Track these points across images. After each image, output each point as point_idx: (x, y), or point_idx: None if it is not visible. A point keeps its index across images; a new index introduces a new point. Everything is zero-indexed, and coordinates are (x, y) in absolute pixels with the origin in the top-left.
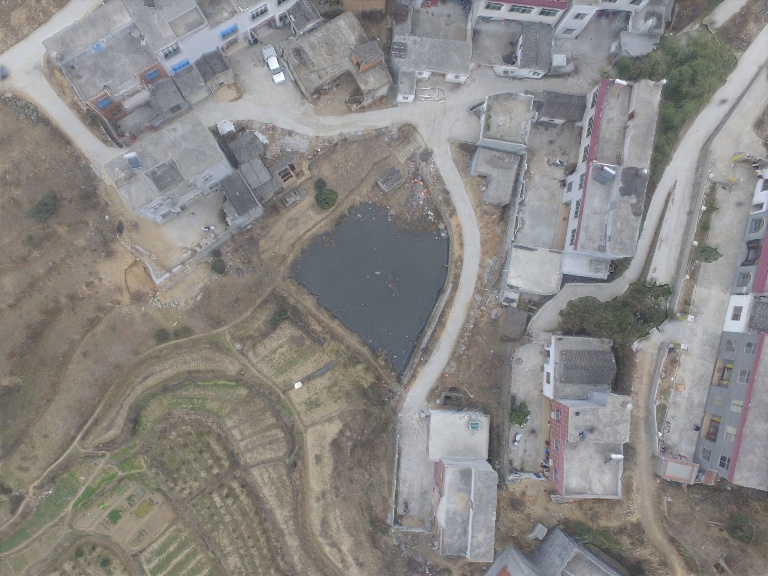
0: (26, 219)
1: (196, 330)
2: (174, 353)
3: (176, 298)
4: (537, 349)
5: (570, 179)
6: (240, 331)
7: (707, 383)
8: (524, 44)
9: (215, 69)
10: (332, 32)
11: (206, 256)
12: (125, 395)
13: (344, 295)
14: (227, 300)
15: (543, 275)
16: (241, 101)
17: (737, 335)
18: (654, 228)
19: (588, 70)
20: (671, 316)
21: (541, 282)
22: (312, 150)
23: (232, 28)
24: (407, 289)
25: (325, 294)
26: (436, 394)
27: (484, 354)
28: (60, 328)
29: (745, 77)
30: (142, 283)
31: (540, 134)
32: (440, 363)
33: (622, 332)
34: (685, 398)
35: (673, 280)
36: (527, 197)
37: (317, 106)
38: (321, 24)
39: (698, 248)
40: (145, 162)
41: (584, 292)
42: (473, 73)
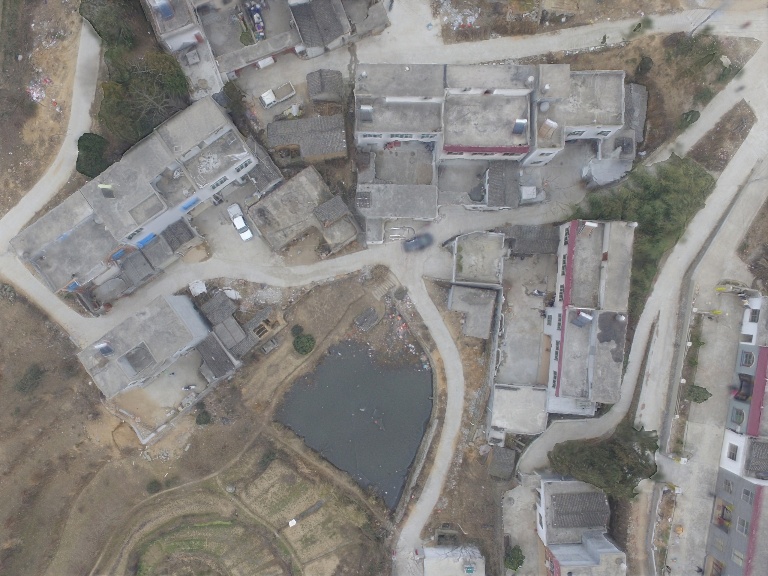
0: (13, 393)
1: (187, 479)
2: (168, 499)
3: (165, 450)
4: (528, 487)
5: (549, 311)
6: (230, 476)
7: (707, 521)
8: (491, 181)
9: (181, 239)
10: (295, 189)
11: (190, 409)
12: (124, 544)
13: (330, 434)
14: (215, 448)
15: (528, 414)
16: (211, 260)
17: (734, 477)
18: (640, 360)
19: (561, 195)
20: (663, 454)
21: (526, 421)
22: (286, 300)
23: (194, 202)
24: (394, 421)
25: (311, 435)
26: (430, 531)
27: (475, 491)
28: (55, 488)
29: (725, 197)
30: (130, 441)
31: (516, 264)
32: (431, 499)
33: (610, 487)
34: (684, 538)
35: (663, 416)
36: (506, 332)
37: (287, 257)
38: (283, 182)
39: (686, 386)
40: (117, 349)
41: (572, 428)
42: (442, 209)
